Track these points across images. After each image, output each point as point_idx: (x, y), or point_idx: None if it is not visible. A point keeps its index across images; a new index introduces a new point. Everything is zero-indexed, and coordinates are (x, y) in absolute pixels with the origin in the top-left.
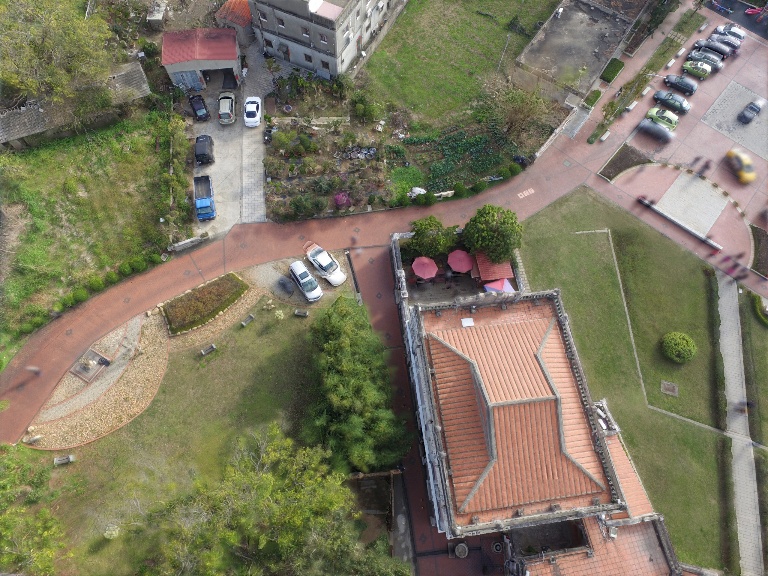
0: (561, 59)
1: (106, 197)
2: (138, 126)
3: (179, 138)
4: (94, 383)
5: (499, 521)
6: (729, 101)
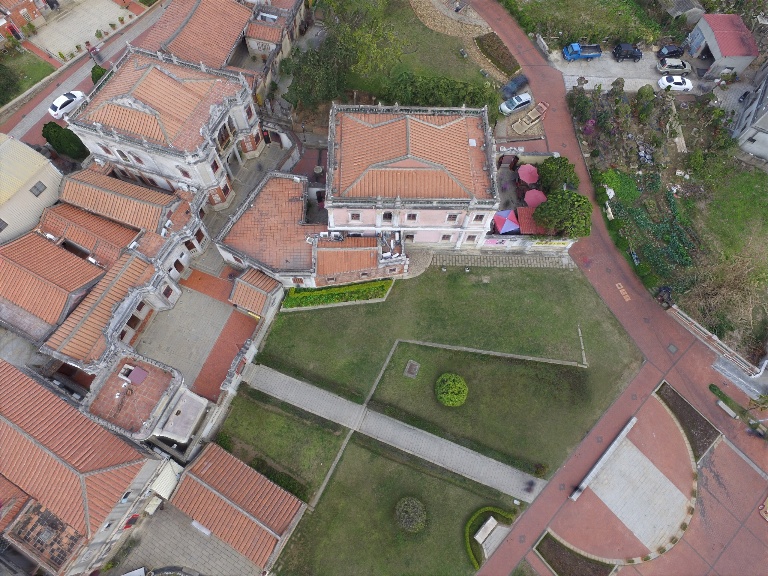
0: None
1: (576, 6)
2: (643, 19)
3: (632, 29)
4: (445, 6)
5: None
6: None
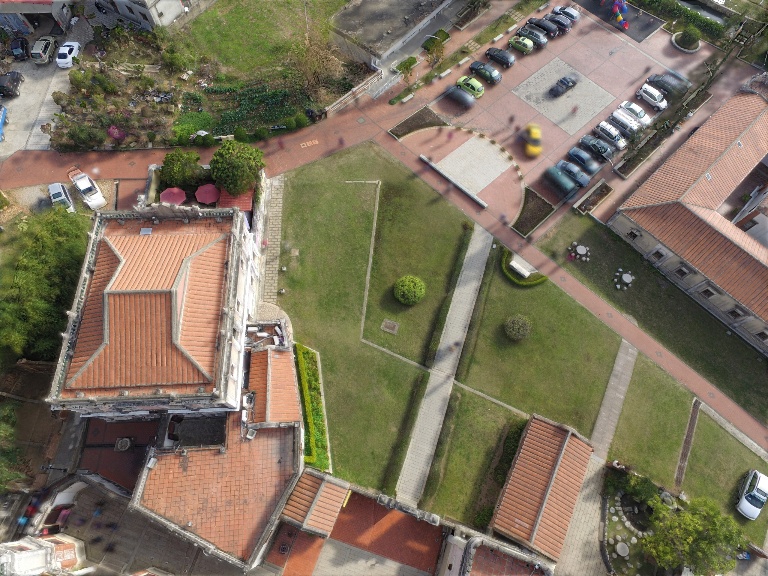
0: (369, 23)
1: None
2: None
3: None
4: None
5: (96, 396)
6: (547, 75)
